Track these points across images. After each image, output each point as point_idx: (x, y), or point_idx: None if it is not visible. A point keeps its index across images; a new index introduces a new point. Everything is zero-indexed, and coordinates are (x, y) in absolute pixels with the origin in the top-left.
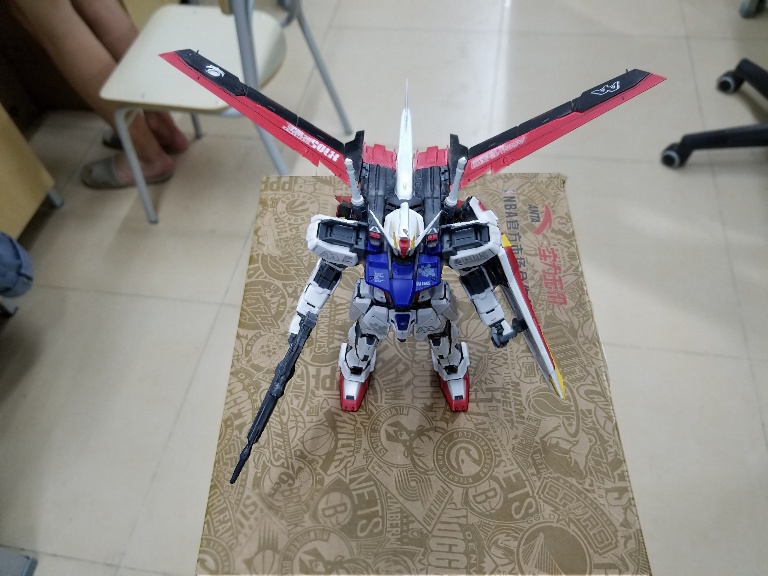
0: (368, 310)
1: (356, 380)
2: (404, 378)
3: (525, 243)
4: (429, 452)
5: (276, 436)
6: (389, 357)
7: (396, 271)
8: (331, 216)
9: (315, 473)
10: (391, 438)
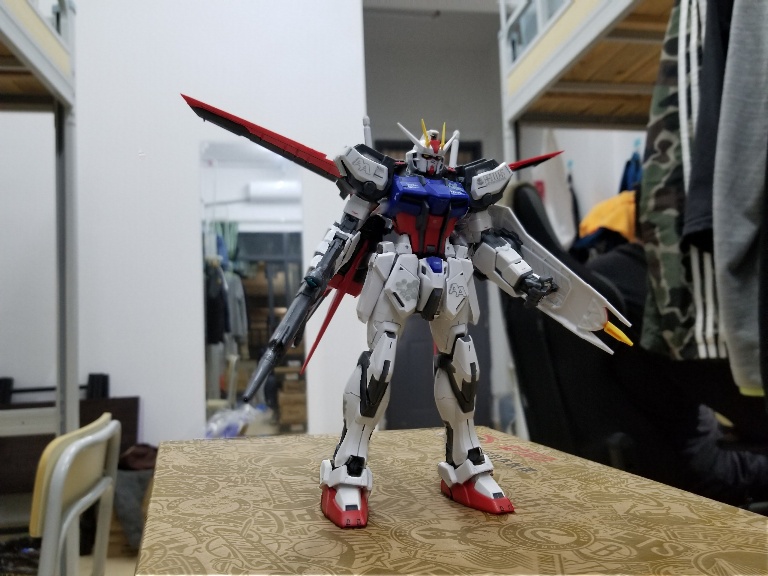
0: (392, 268)
1: (356, 482)
2: (413, 507)
3: (482, 446)
4: (495, 538)
5: (246, 550)
6: (382, 499)
7: (428, 181)
8: (254, 450)
9: (331, 569)
10: (431, 537)
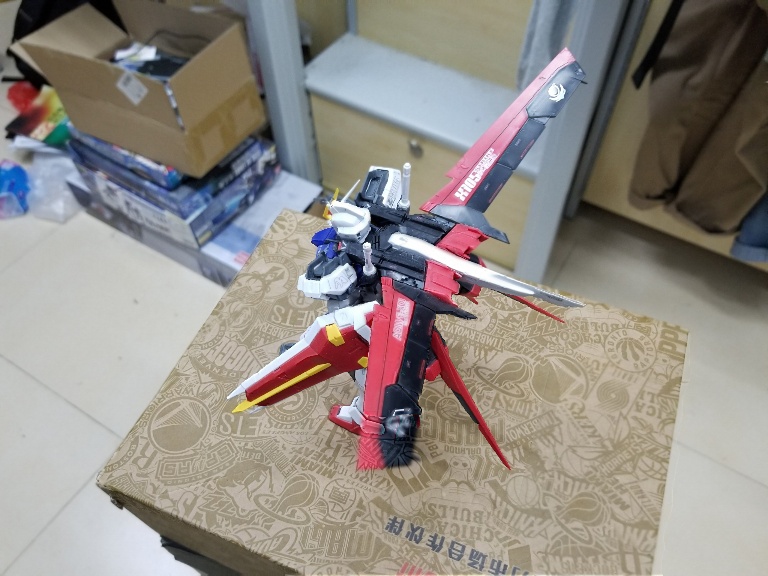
0: None
1: None
2: None
3: None
4: None
5: None
6: None
7: None
8: (610, 379)
9: None
10: None
